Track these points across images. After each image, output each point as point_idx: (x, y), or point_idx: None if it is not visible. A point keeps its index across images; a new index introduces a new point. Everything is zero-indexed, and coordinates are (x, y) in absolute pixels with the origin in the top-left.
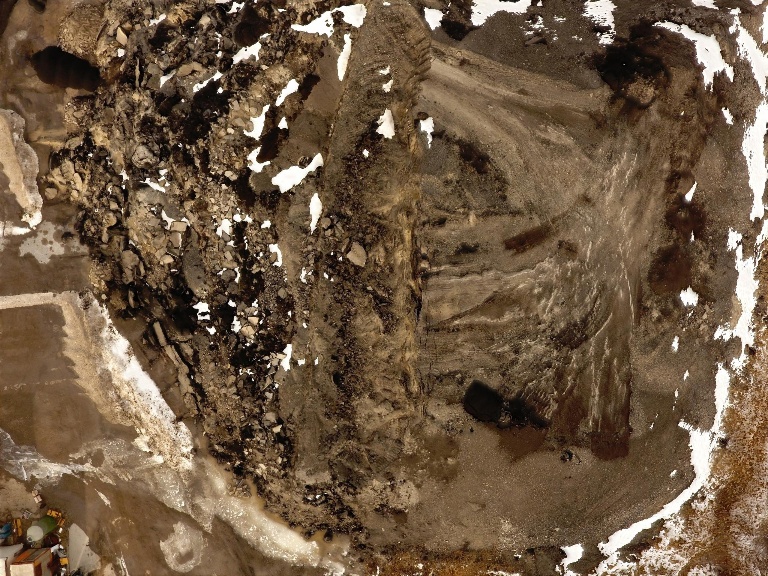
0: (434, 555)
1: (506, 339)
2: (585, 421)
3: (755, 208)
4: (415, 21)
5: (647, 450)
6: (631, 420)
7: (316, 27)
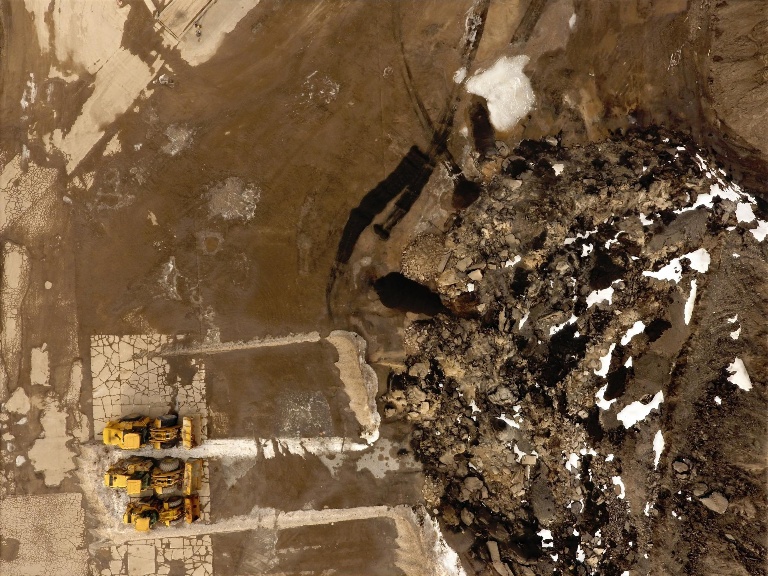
0: None
1: None
2: None
3: None
4: None
5: None
6: None
7: (666, 274)
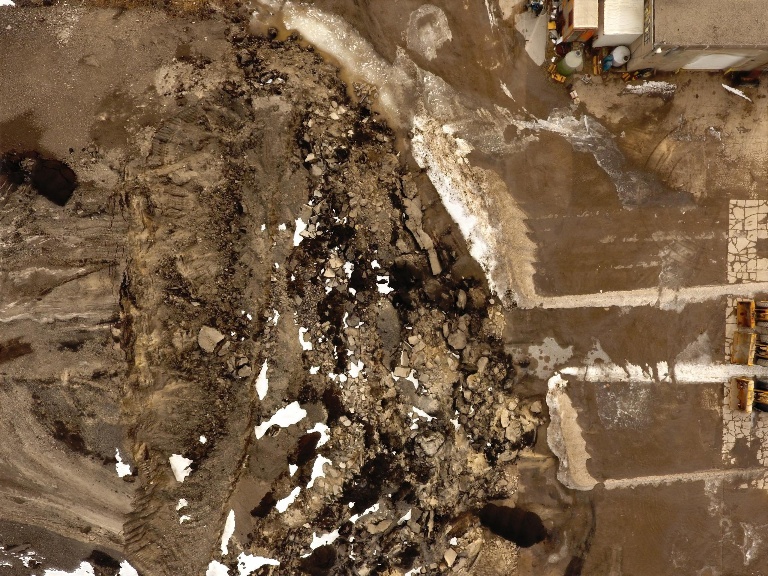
0: (157, 5)
1: (29, 248)
2: None
3: None
4: (150, 567)
5: None
6: None
7: (255, 562)
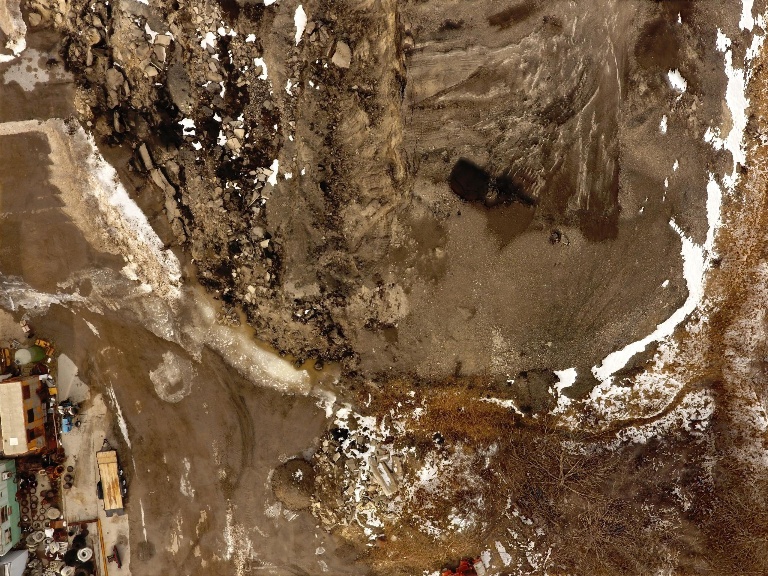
0: (426, 382)
1: (492, 116)
2: (573, 199)
3: (744, 18)
4: None
5: (637, 237)
6: (620, 198)
7: None
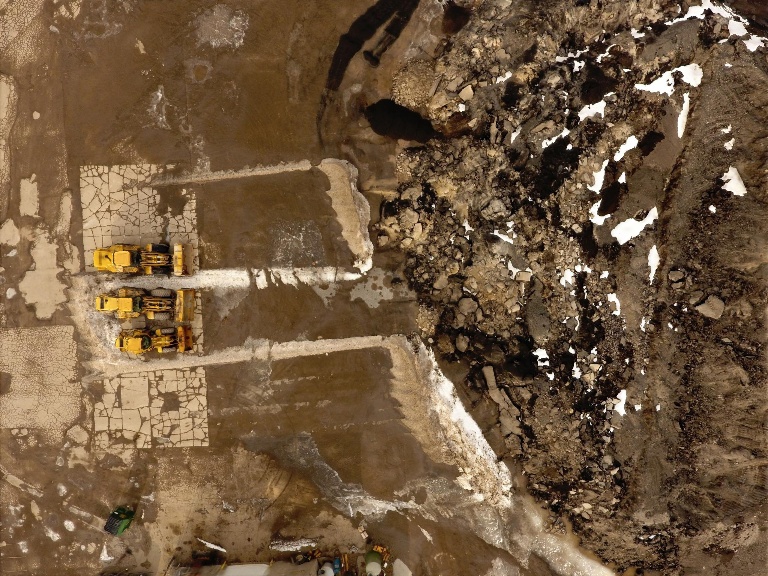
0: None
1: None
2: None
3: None
4: (761, 83)
5: None
6: None
7: (658, 86)
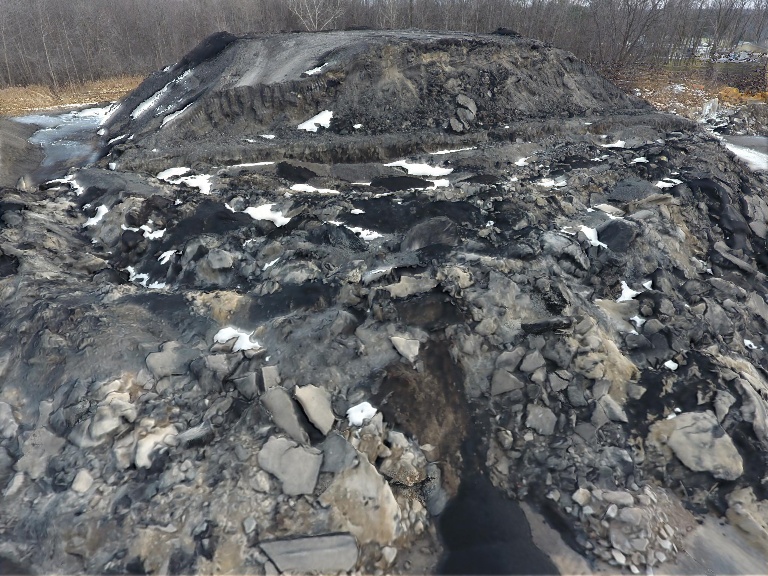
0: None
1: None
2: None
3: None
4: (180, 127)
5: None
6: None
7: (200, 182)
